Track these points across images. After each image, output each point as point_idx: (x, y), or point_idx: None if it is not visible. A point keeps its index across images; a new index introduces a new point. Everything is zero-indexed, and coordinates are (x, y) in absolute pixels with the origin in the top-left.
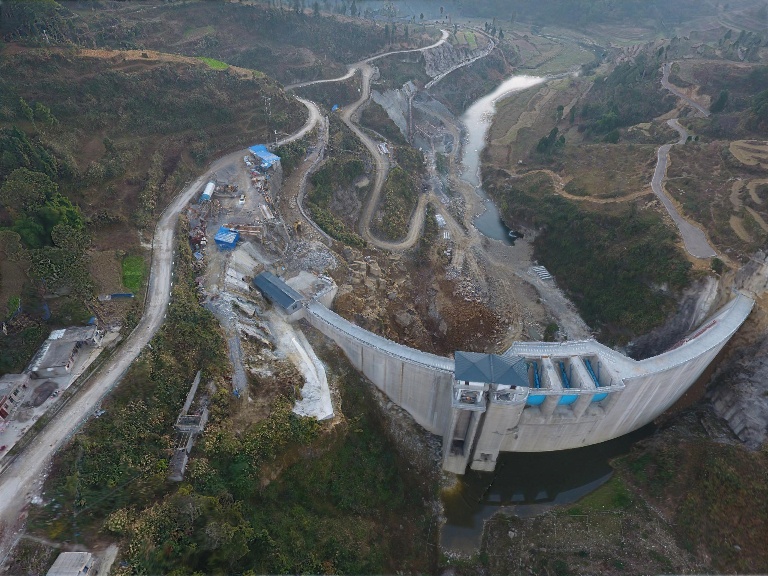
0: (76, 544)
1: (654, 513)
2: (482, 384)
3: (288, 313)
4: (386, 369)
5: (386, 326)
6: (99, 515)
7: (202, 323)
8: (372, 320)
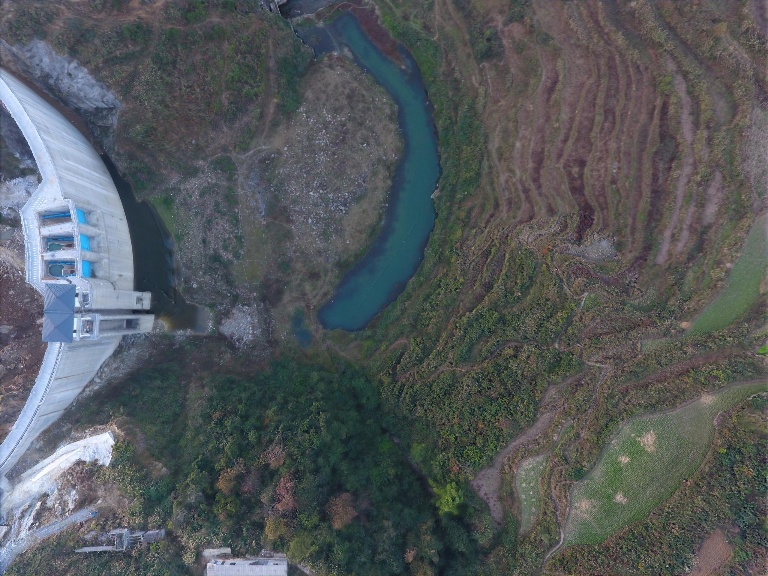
0: (204, 575)
1: (175, 184)
2: (75, 319)
3: (1, 493)
4: (62, 391)
5: (7, 390)
6: (187, 571)
7: (23, 569)
8: (3, 407)
